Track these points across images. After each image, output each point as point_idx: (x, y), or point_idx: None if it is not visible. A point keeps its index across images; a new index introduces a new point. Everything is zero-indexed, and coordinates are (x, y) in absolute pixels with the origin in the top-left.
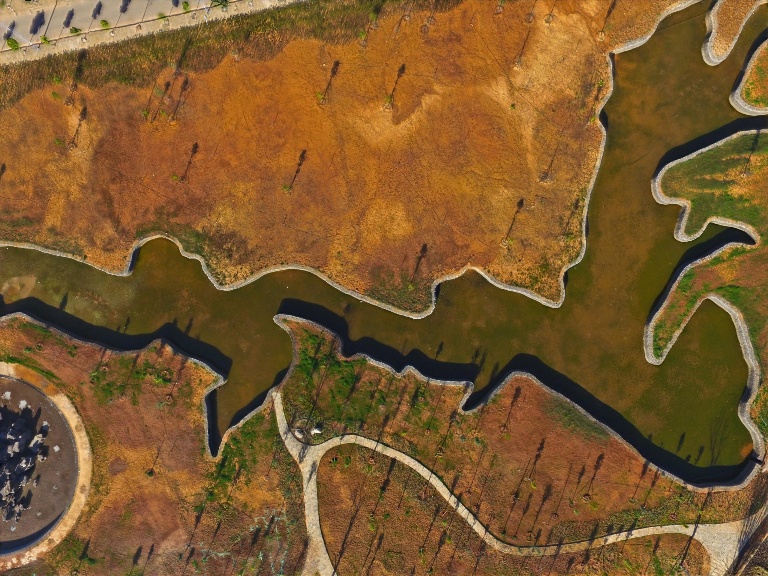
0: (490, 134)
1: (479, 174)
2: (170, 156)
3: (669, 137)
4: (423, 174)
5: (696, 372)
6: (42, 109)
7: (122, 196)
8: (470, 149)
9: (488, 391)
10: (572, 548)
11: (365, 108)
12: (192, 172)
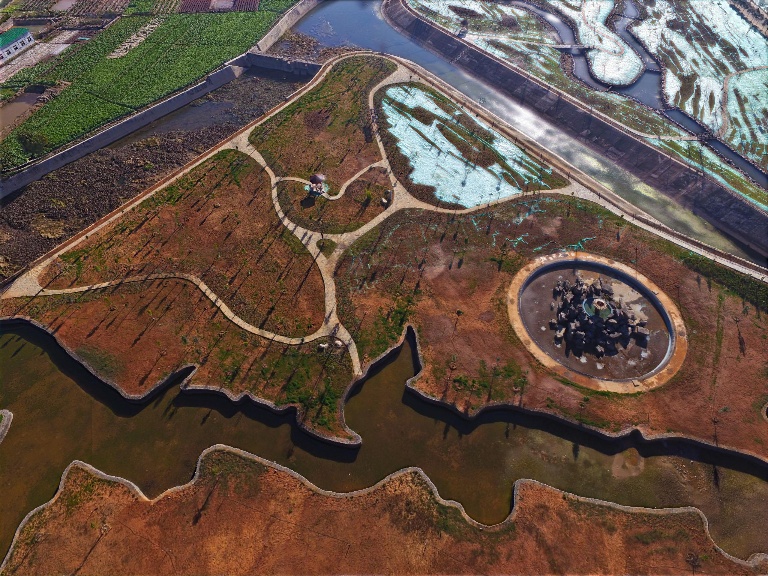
0: None
1: None
2: None
3: None
4: None
5: None
6: None
7: (541, 575)
8: None
9: (170, 384)
10: (137, 278)
11: None
12: None
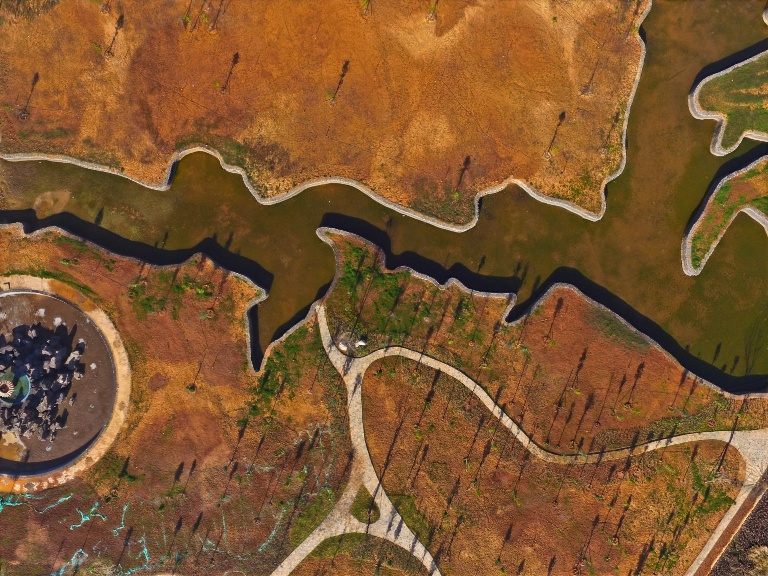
0: (532, 47)
1: (522, 86)
2: (210, 66)
3: (705, 53)
4: (466, 86)
5: (731, 284)
6: (77, 17)
7: (161, 107)
8: (513, 61)
9: (530, 304)
10: (613, 456)
11: (408, 19)
12: (233, 83)
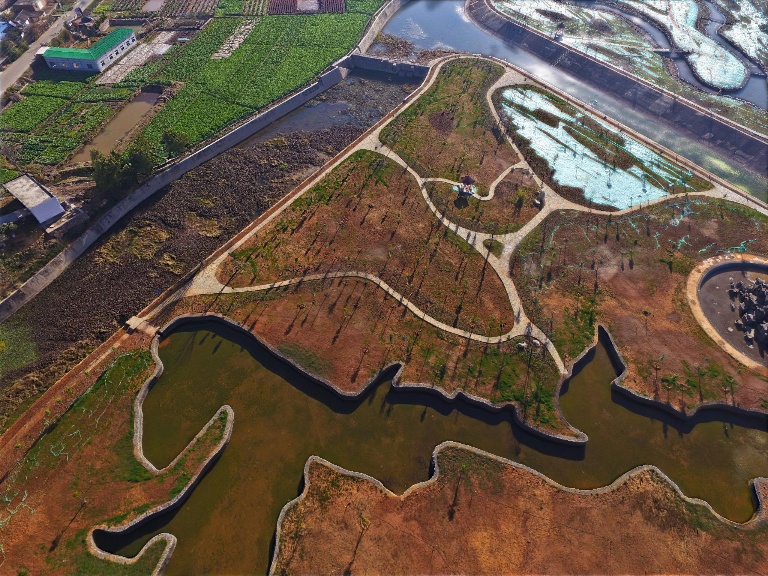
0: None
1: None
2: None
3: None
4: None
5: (190, 402)
6: None
7: None
8: None
9: (378, 382)
10: (316, 277)
11: None
12: None
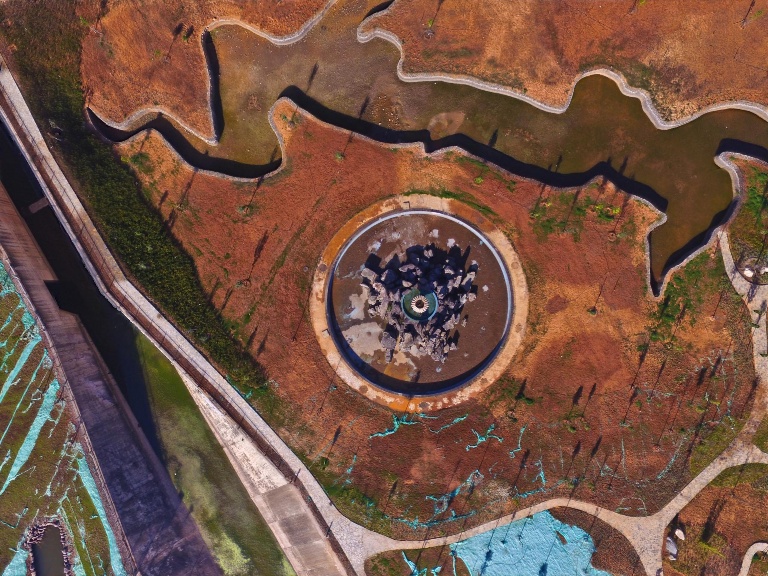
0: None
1: None
2: None
3: None
4: None
5: None
6: None
7: (567, 28)
8: None
9: None
10: None
11: None
12: (641, 4)
